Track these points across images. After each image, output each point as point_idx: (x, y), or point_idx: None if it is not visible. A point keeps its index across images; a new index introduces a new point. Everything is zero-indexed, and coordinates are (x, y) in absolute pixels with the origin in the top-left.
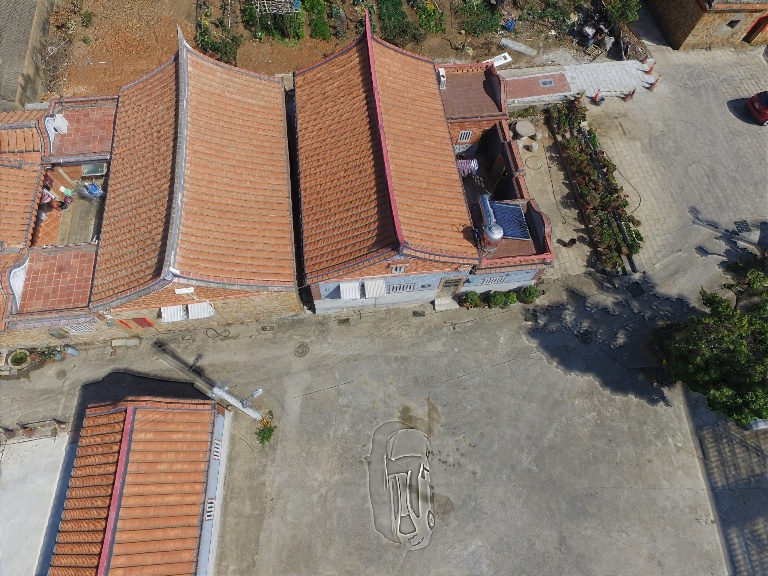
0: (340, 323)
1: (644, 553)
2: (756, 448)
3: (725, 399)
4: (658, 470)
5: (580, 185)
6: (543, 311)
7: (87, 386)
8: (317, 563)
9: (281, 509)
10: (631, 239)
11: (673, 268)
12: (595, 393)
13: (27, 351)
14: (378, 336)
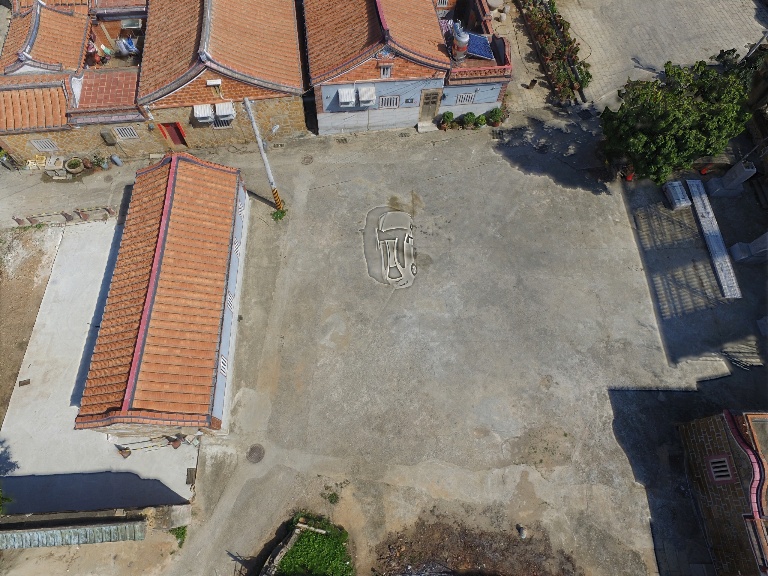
0: (339, 142)
1: (585, 289)
2: (680, 222)
3: (643, 149)
4: (599, 236)
5: (541, 42)
6: (508, 132)
7: (130, 186)
8: (322, 297)
9: (293, 263)
10: (582, 77)
11: (617, 98)
12: (549, 187)
13: (80, 159)
14: (371, 150)
